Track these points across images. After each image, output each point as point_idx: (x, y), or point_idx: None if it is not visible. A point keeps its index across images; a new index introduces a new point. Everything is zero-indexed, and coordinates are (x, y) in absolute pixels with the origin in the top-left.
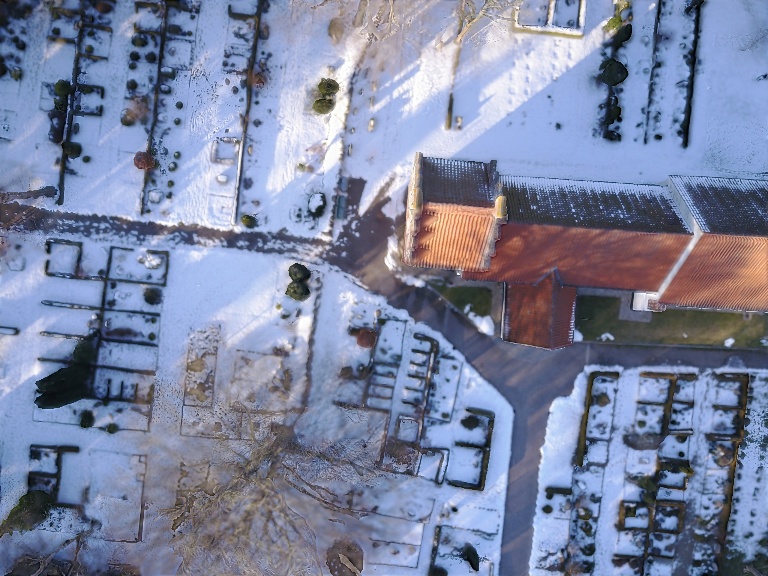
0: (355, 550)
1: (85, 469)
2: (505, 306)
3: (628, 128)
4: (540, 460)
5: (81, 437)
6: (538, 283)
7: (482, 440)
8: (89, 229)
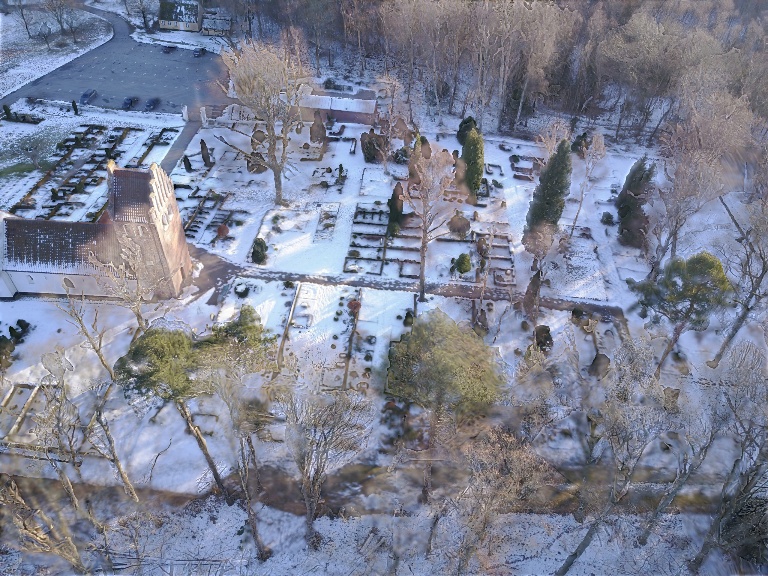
0: None
1: None
2: None
3: (8, 331)
4: None
5: None
6: None
7: None
8: (396, 284)
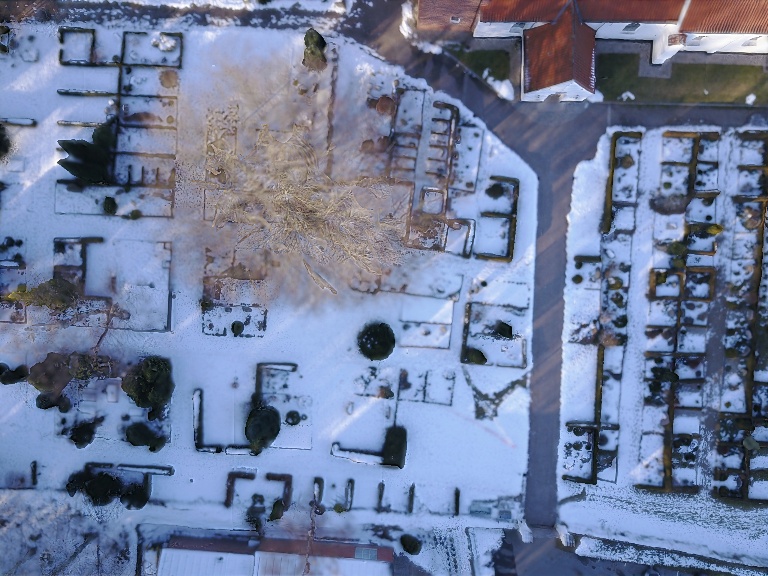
0: (386, 326)
1: (110, 260)
2: (524, 58)
3: None
4: (567, 228)
5: (104, 227)
6: (557, 19)
7: (508, 209)
8: (101, 16)
